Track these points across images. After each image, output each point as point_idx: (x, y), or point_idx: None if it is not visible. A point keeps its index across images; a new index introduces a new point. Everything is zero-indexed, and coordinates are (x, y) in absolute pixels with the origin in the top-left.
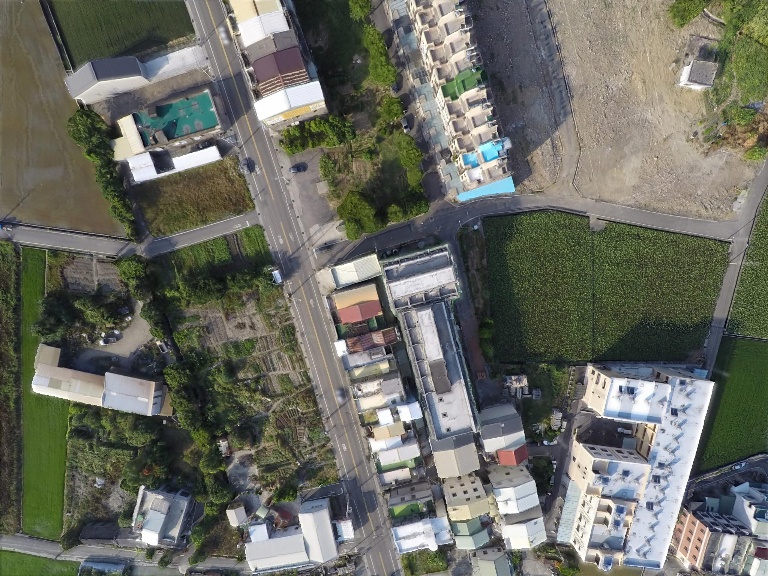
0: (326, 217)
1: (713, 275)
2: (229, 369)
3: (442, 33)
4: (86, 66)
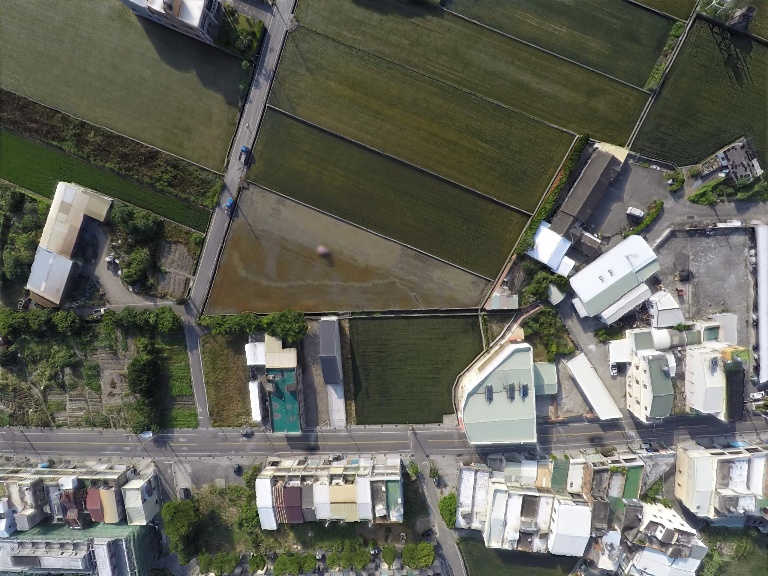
0: (196, 479)
1: None
2: (72, 365)
3: None
4: (334, 350)
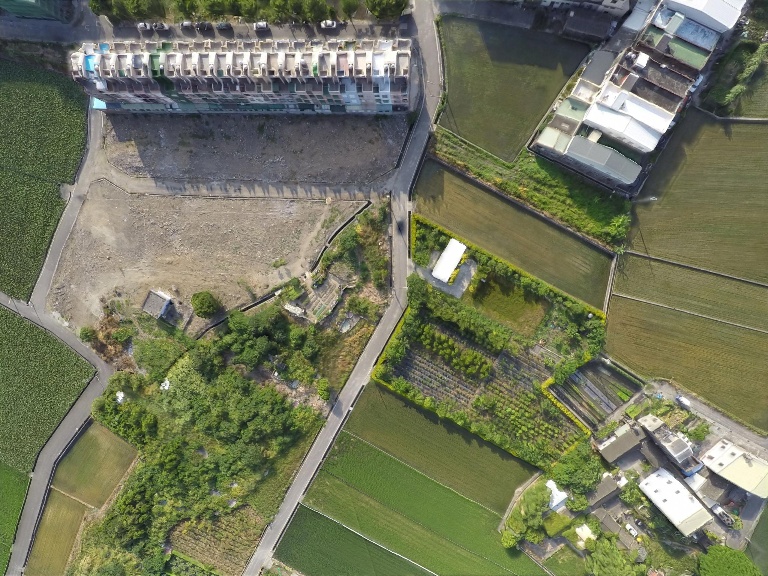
0: None
1: (2, 281)
2: None
3: (207, 52)
4: None
